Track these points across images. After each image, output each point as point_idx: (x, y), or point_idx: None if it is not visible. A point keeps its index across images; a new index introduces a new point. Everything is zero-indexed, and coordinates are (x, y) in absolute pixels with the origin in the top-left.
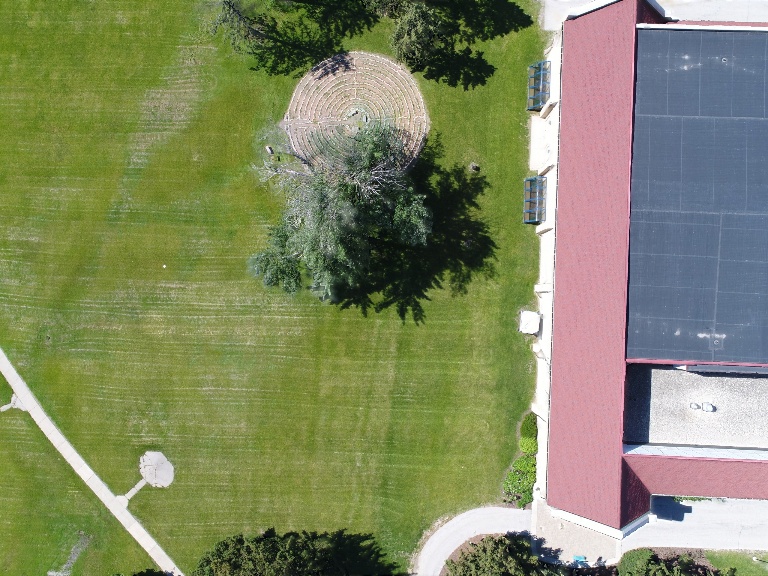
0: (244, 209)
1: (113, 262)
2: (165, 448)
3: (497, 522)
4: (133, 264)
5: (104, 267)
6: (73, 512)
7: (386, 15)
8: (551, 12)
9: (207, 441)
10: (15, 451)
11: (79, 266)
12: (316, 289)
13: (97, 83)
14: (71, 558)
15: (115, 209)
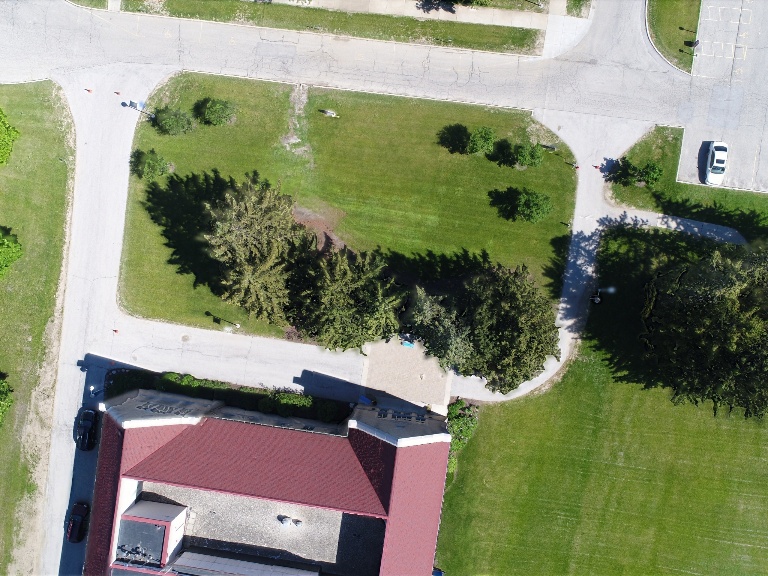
0: None
1: None
2: None
3: None
4: None
5: None
6: None
7: None
8: None
9: None
10: None
11: None
12: None
13: None
14: None
15: None
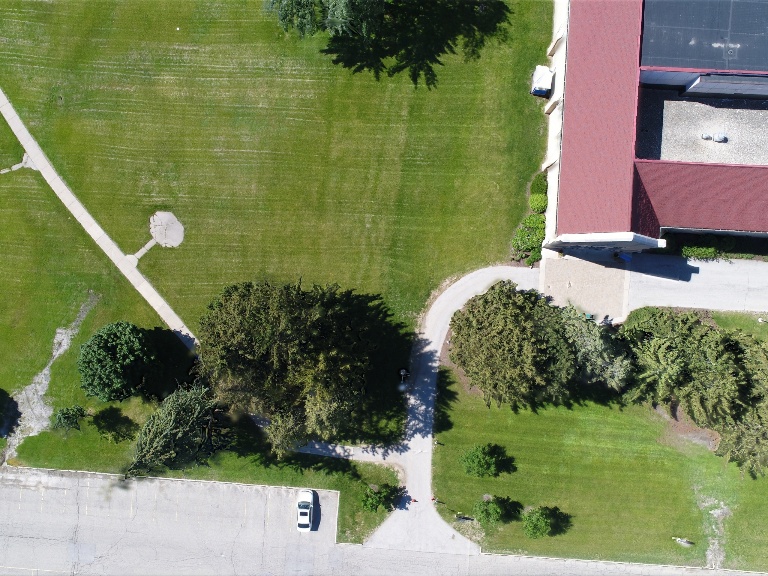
0: None
1: (127, 24)
2: (175, 208)
3: None
4: (147, 26)
5: (118, 29)
6: (83, 270)
7: None
8: None
9: (217, 202)
10: (26, 210)
11: (93, 27)
12: (329, 52)
13: None
14: (80, 316)
15: None
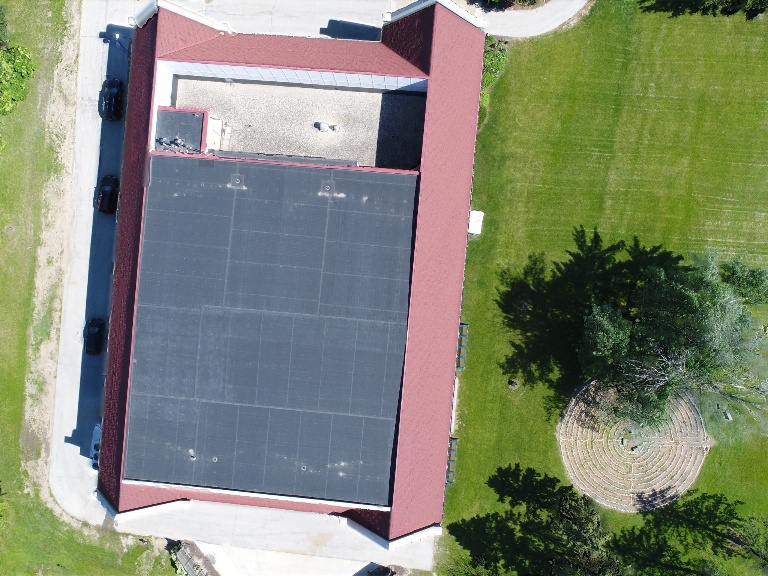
0: None
1: None
2: None
3: (514, 22)
4: None
5: None
6: None
7: None
8: None
9: None
10: None
11: None
12: (687, 268)
13: None
14: None
15: None
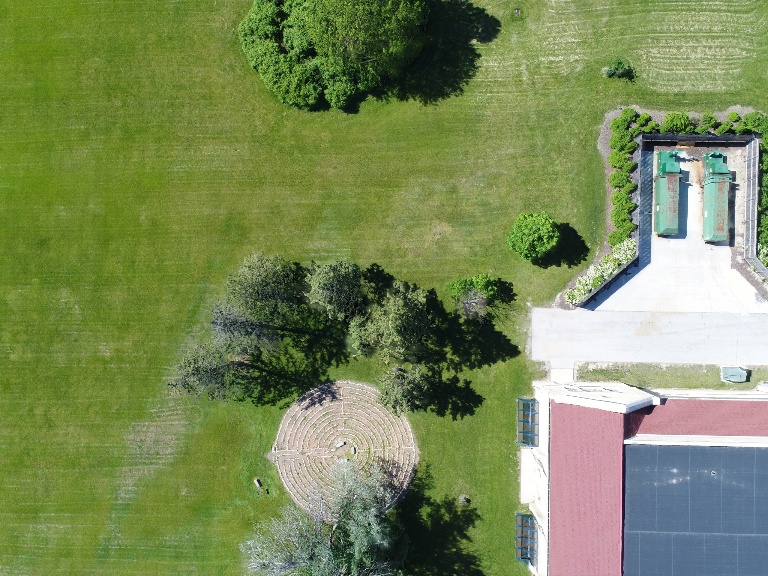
0: (234, 544)
1: None
2: None
3: None
4: None
5: None
6: None
7: (372, 343)
8: (538, 342)
9: None
10: None
11: None
12: None
13: (82, 417)
14: None
15: (104, 545)
